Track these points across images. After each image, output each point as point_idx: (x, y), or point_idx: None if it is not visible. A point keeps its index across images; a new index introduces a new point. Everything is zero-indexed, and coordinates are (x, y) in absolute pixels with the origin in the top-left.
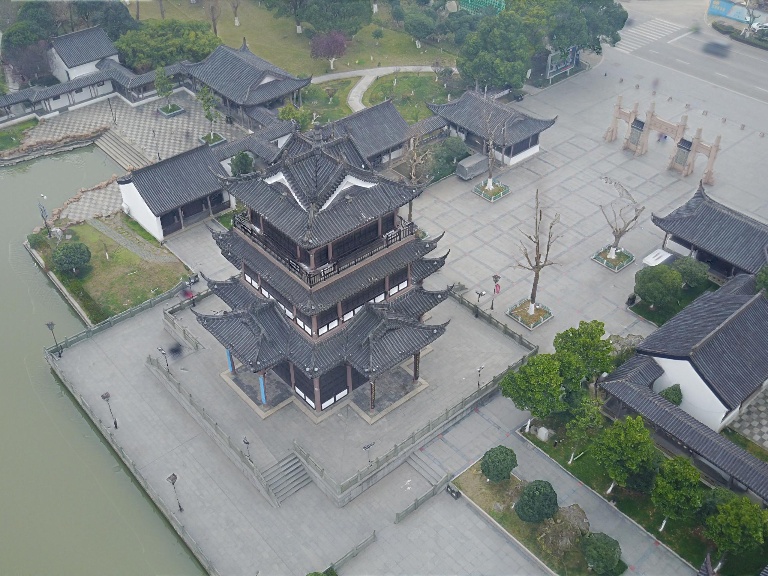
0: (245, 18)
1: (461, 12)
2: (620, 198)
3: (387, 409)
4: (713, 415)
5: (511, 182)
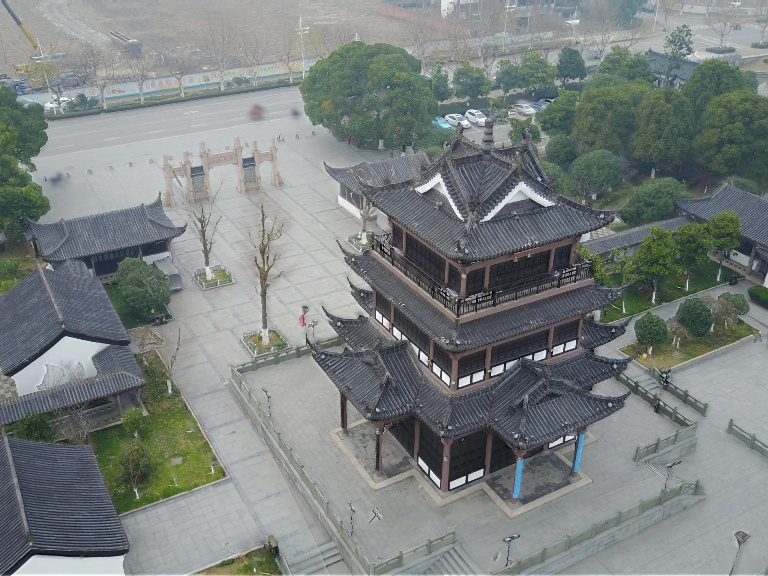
0: None
1: None
2: None
3: None
4: None
5: None
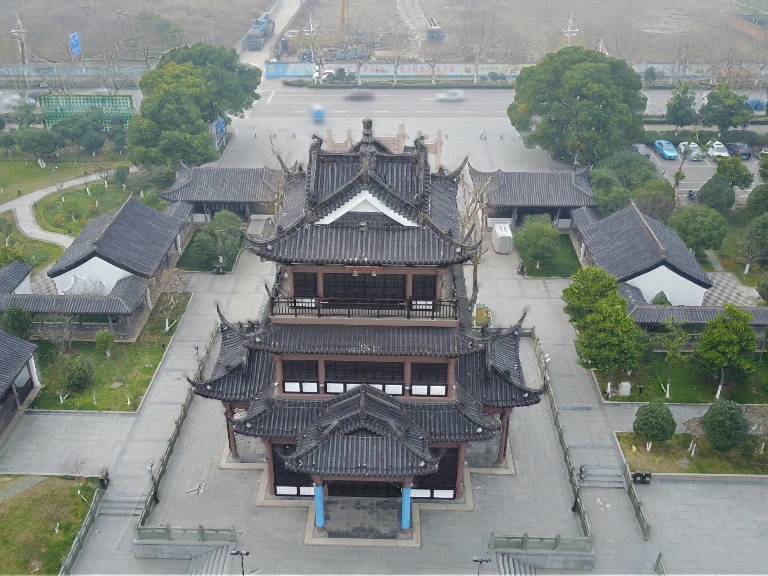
0: None
1: (72, 117)
2: None
3: (507, 452)
4: (695, 303)
5: None
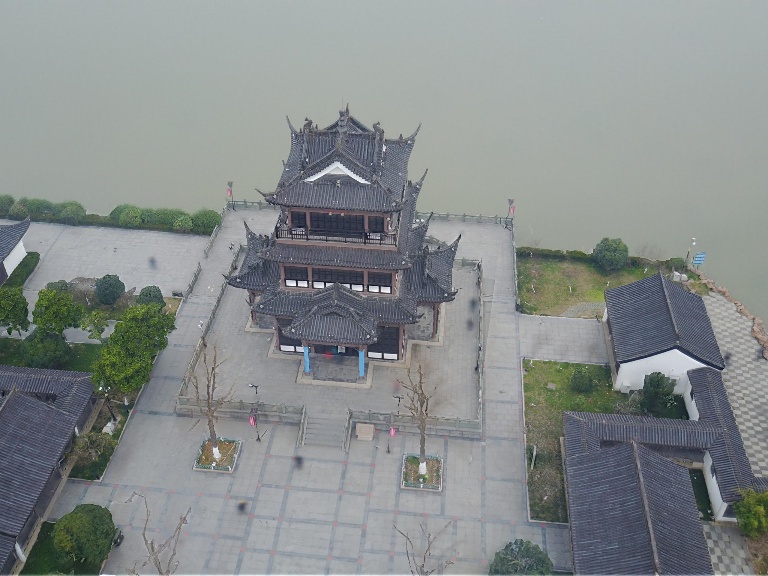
0: None
1: None
2: None
3: (259, 300)
4: None
5: None
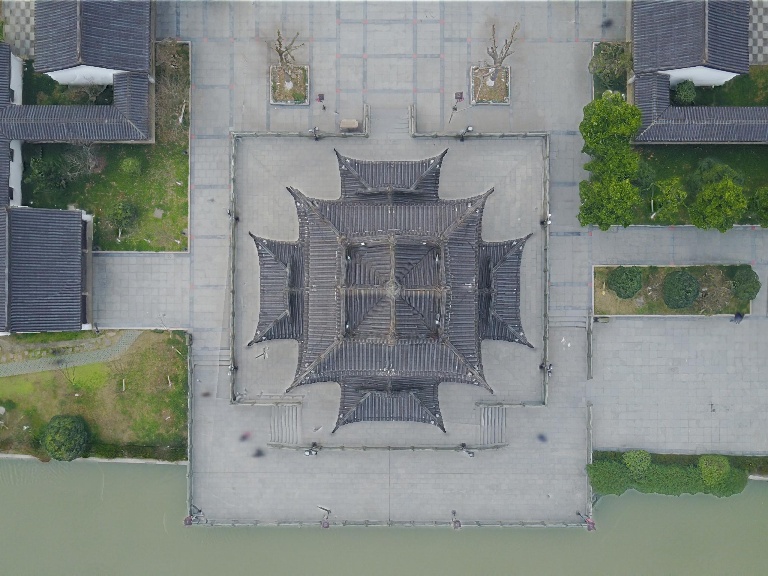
0: None
1: None
2: None
3: None
4: (724, 80)
5: None
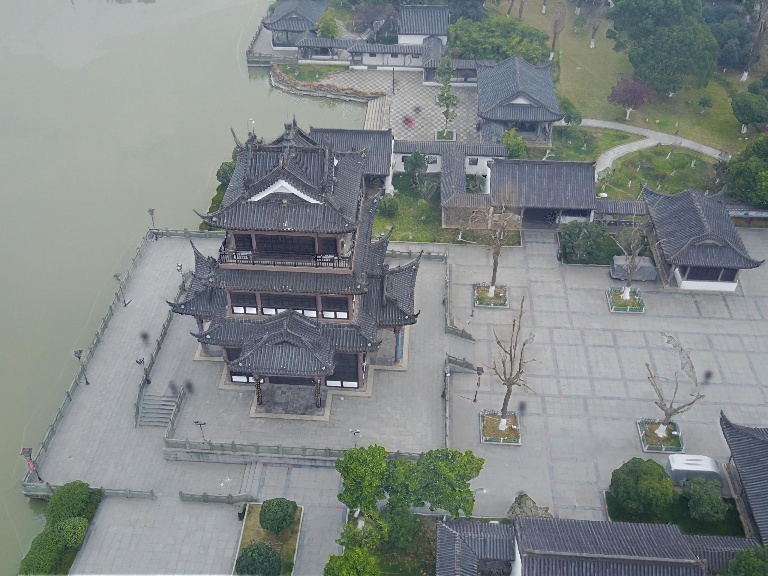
0: (607, 43)
1: None
2: (762, 386)
3: (274, 414)
4: None
5: (659, 304)
